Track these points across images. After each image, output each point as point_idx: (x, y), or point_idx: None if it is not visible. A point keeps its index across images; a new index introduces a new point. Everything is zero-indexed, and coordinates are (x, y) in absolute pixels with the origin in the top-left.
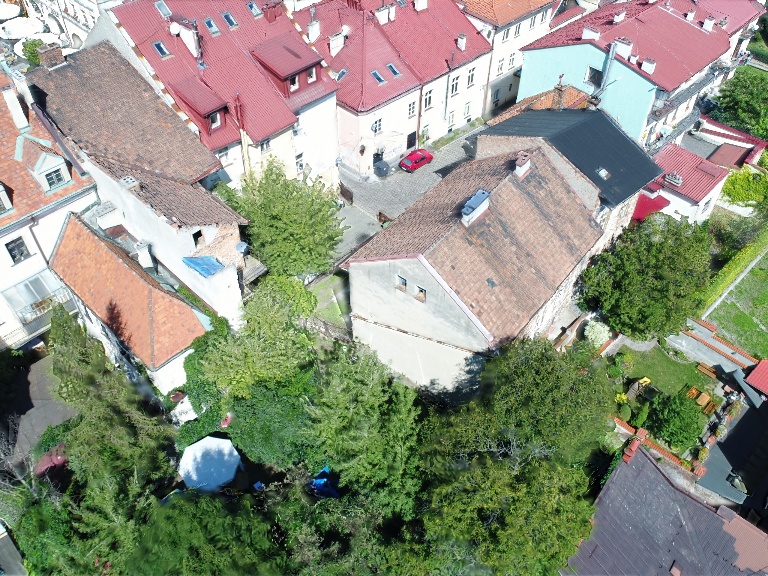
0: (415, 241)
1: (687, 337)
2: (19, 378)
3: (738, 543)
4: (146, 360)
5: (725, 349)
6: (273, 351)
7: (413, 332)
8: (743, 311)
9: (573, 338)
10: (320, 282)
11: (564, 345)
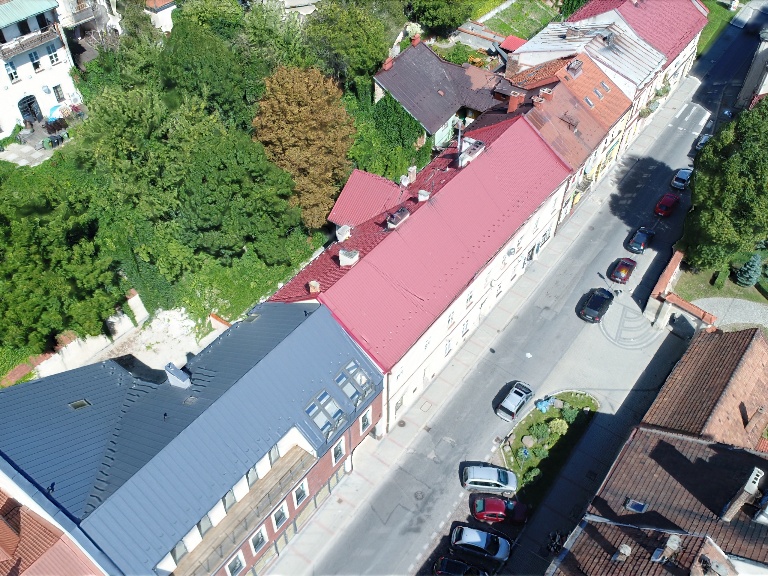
0: None
1: (471, 36)
2: (74, 43)
3: (473, 78)
4: (151, 5)
5: (490, 36)
6: (220, 3)
7: (299, 4)
8: (505, 22)
9: (402, 37)
10: (245, 15)
11: (396, 40)
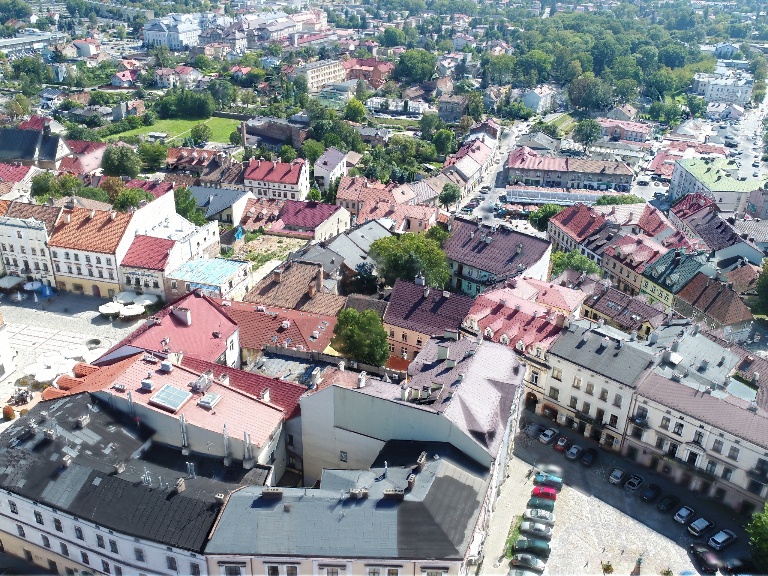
0: (6, 188)
1: None
2: None
3: None
4: None
5: None
6: None
7: None
8: None
9: None
10: None
11: None
